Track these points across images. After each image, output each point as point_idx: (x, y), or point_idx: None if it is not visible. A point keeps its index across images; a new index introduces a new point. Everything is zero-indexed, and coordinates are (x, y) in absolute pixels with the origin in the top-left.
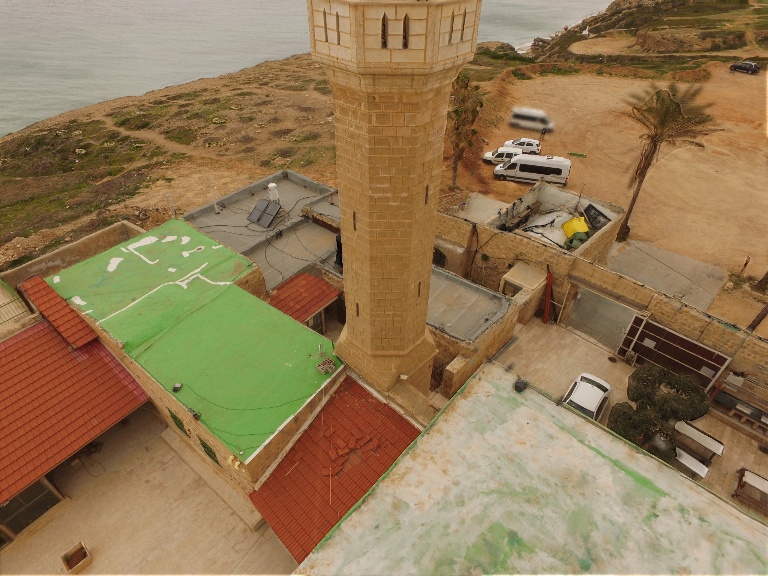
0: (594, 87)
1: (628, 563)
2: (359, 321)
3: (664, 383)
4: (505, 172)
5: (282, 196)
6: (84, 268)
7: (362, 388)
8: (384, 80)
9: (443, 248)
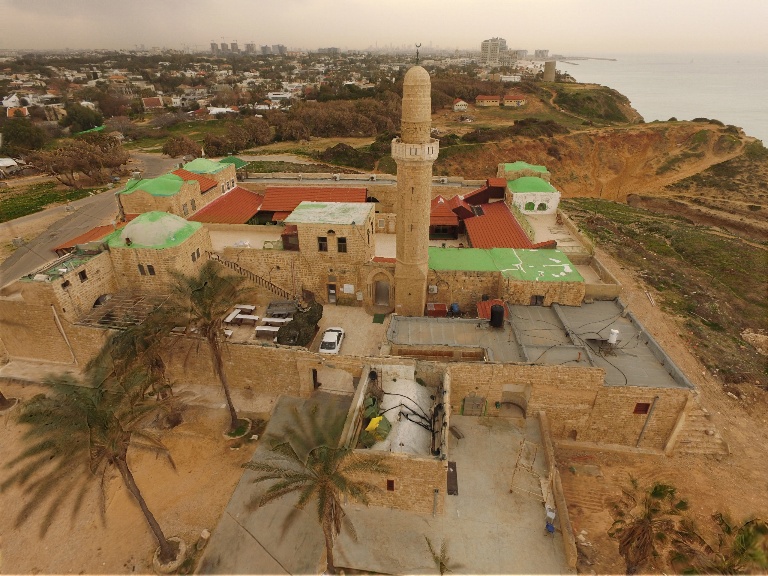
0: None
1: None
2: None
3: (296, 340)
4: None
5: (642, 372)
6: (560, 256)
7: None
8: None
9: None
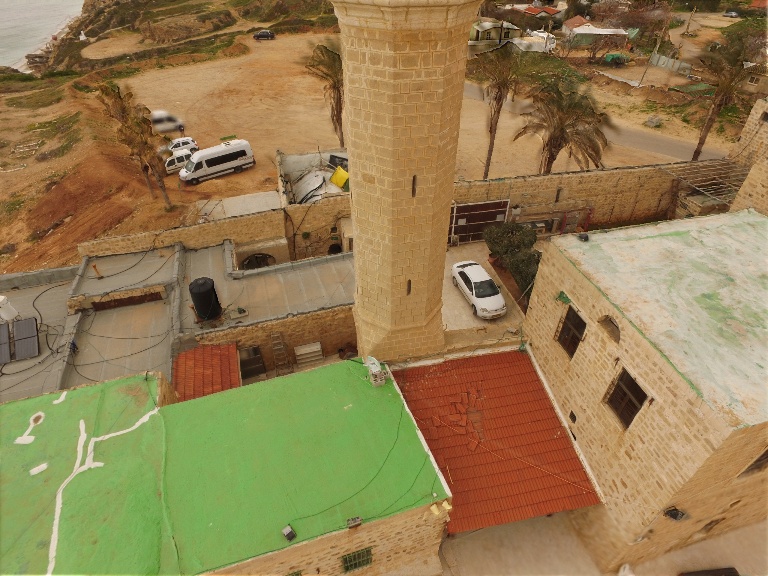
0: (170, 80)
1: (731, 265)
2: (410, 298)
3: None
4: (195, 175)
5: None
6: None
7: (416, 368)
8: (463, 10)
9: (266, 249)
